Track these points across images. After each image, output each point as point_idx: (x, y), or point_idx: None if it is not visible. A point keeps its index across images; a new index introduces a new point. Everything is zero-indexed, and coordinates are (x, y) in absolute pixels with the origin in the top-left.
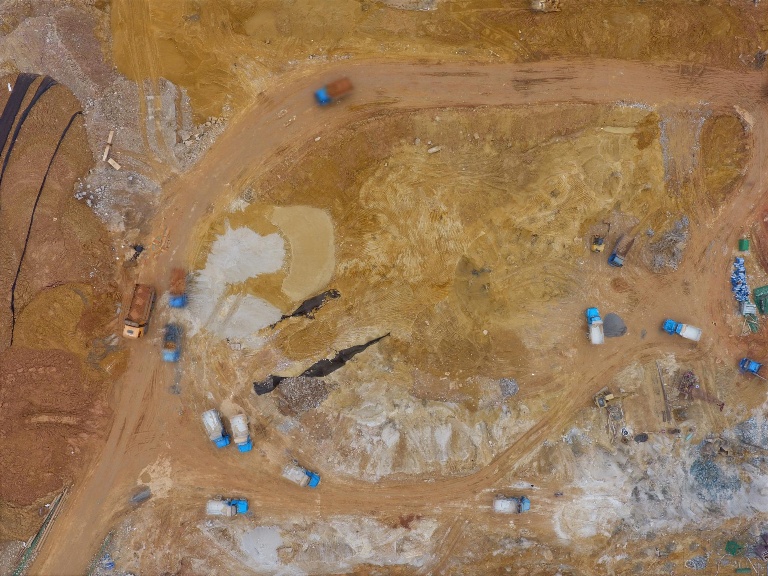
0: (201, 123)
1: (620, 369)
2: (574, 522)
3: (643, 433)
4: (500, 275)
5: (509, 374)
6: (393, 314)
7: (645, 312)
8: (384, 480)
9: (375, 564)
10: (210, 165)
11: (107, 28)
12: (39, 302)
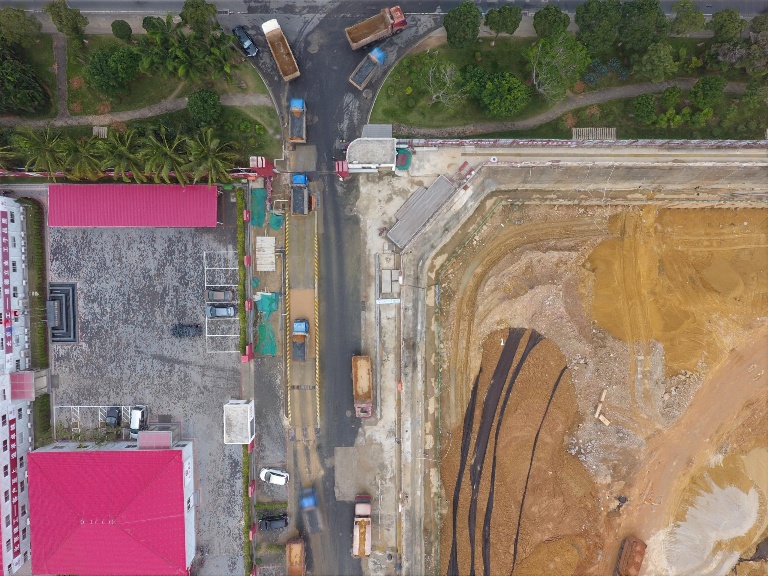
0: (673, 375)
1: None
2: None
3: None
4: None
5: None
6: None
7: None
8: None
9: None
10: (691, 421)
11: (591, 286)
12: (541, 556)
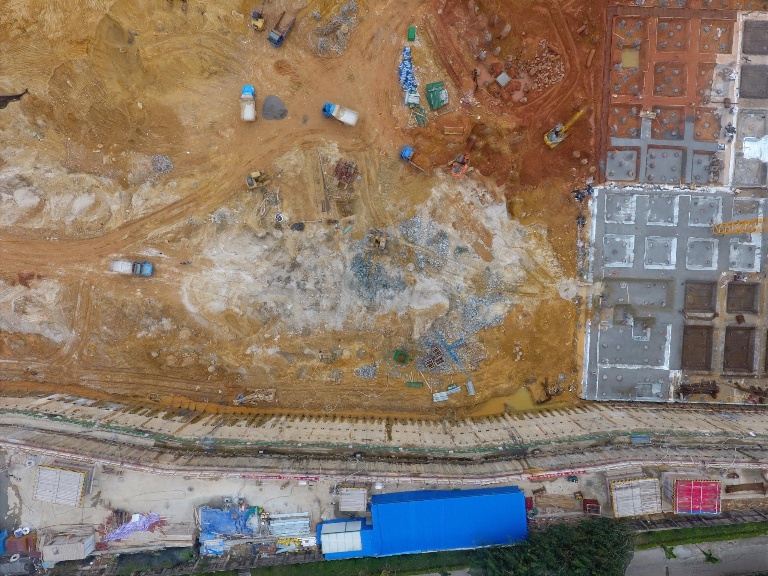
0: None
1: (280, 154)
2: (203, 295)
3: (299, 221)
4: (148, 41)
5: (163, 151)
6: (28, 67)
7: (307, 96)
8: (1, 232)
9: (3, 330)
10: None
11: None
12: None
